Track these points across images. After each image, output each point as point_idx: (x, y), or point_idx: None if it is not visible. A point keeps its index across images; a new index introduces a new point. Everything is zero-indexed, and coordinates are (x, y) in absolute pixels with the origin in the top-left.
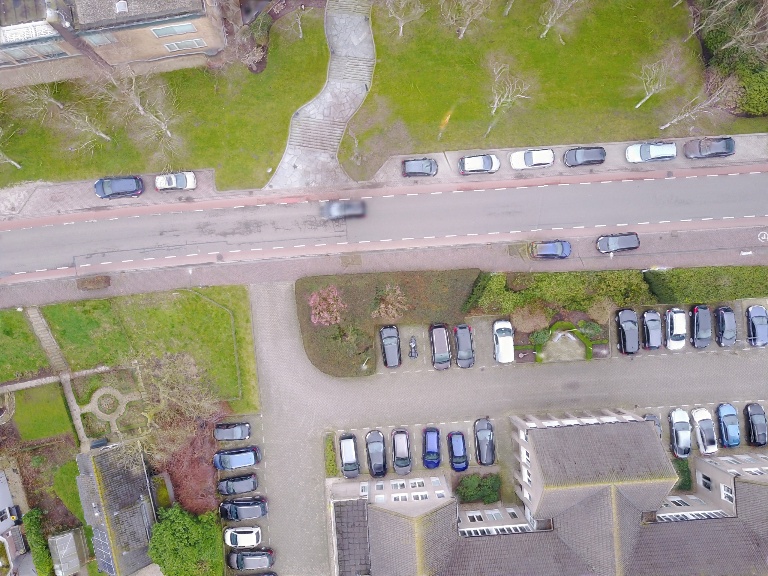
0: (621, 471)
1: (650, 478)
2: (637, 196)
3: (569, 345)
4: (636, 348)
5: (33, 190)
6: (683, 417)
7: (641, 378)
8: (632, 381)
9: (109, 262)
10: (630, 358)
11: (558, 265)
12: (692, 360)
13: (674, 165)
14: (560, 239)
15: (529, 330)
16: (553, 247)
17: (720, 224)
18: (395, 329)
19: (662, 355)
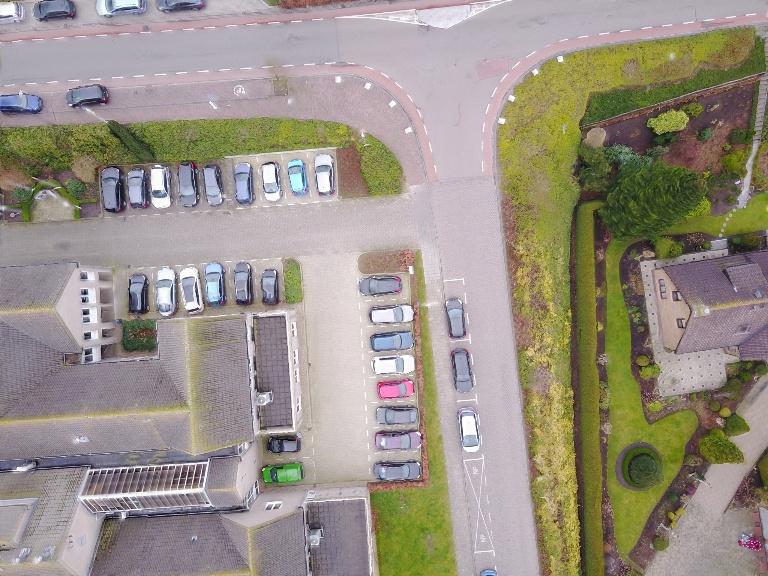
0: (5, 303)
1: (26, 308)
2: (111, 50)
3: (59, 204)
4: (114, 204)
5: None
6: (169, 275)
7: (133, 238)
8: (124, 241)
9: None
10: (123, 218)
11: (30, 120)
12: (185, 220)
13: (149, 19)
14: (33, 94)
15: (11, 187)
16: (14, 99)
17: (194, 78)
18: None
19: (155, 215)
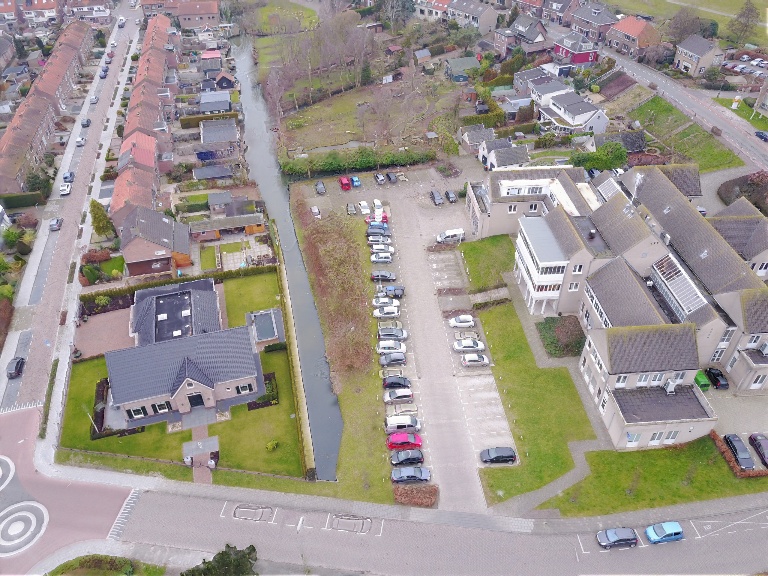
0: None
1: None
2: None
3: None
4: None
5: (743, 121)
6: None
7: None
8: None
9: (727, 136)
10: None
11: None
12: None
13: None
14: None
15: None
16: None
17: None
18: (759, 209)
19: None
